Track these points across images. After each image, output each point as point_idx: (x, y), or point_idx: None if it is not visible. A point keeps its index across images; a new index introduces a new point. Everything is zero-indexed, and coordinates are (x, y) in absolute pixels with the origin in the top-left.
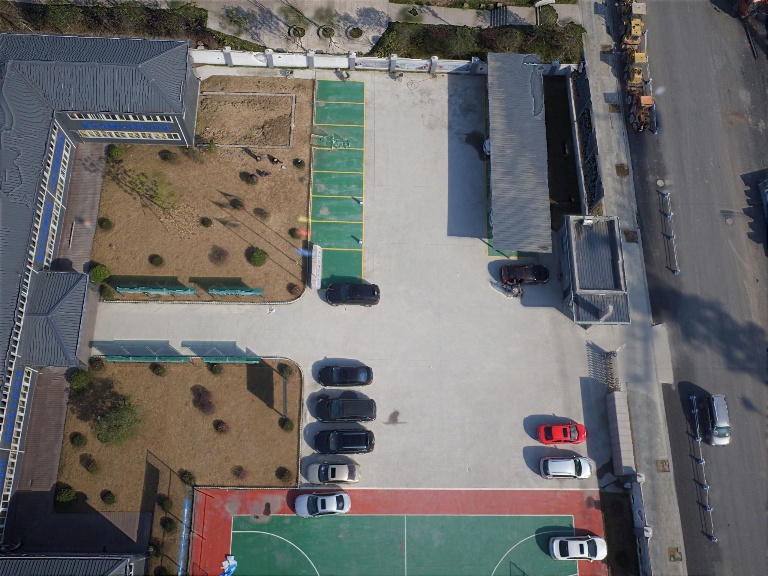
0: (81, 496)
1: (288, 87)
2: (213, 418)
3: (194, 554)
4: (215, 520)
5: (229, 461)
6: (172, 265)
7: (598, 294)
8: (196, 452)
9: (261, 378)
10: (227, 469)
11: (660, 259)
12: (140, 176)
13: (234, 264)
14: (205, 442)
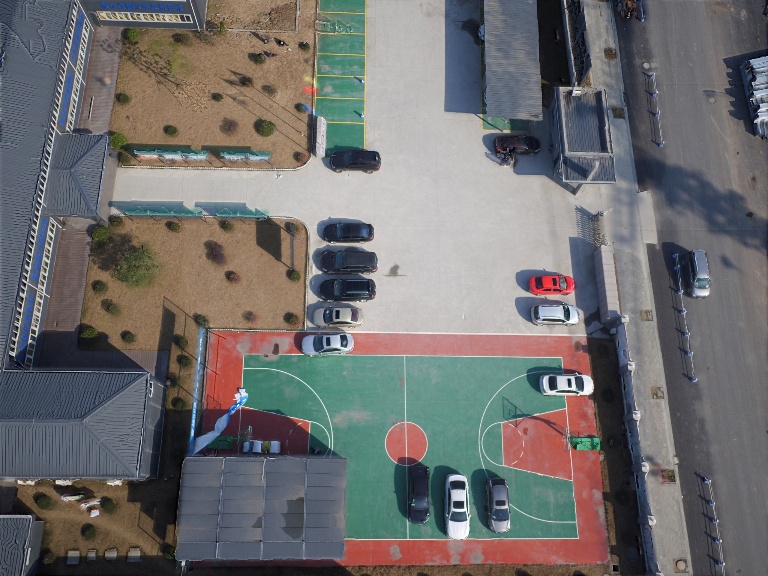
0: (103, 336)
1: None
2: (225, 269)
3: (208, 387)
4: (227, 358)
5: (240, 307)
6: (185, 135)
7: (586, 156)
8: (209, 299)
9: (269, 235)
10: (238, 314)
11: (646, 133)
12: (155, 56)
13: (244, 134)
14: (218, 290)
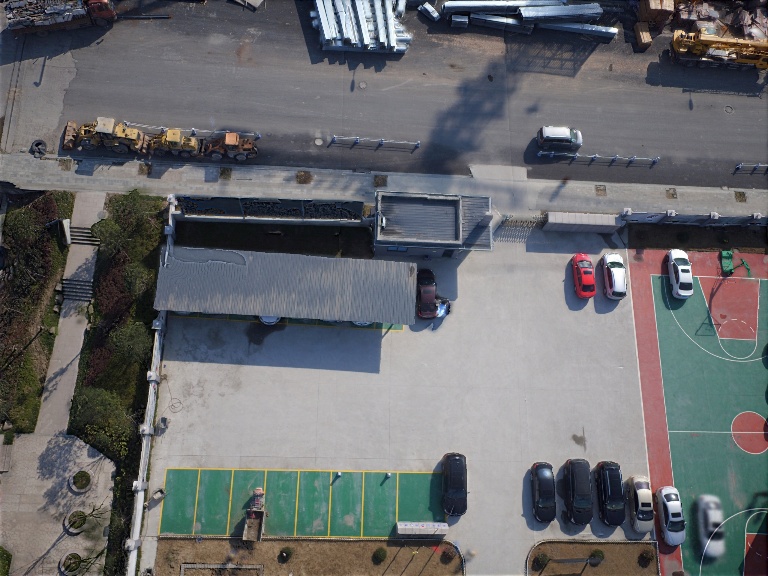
0: None
1: (169, 575)
2: None
3: None
4: None
5: None
6: None
7: None
8: None
9: None
10: None
11: (403, 158)
12: None
13: None
14: None
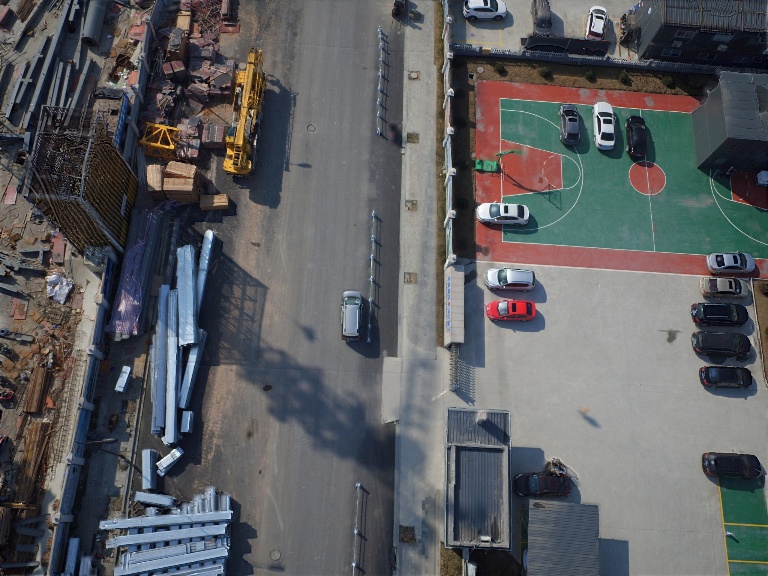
0: None
1: None
2: None
3: None
4: None
5: None
6: None
7: None
8: None
9: None
10: None
11: (375, 504)
12: None
13: None
14: None
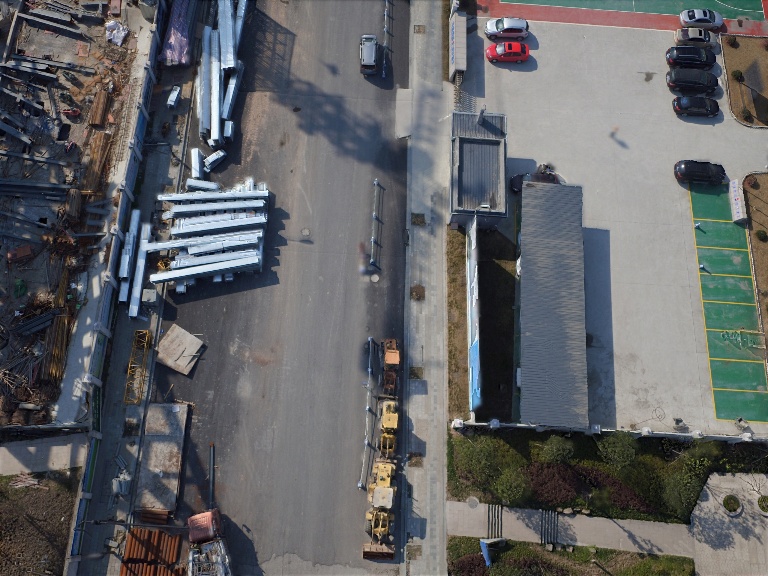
0: None
1: None
2: None
3: None
4: None
5: None
6: None
7: None
8: None
9: (766, 112)
10: None
11: (390, 198)
12: None
13: None
14: None
